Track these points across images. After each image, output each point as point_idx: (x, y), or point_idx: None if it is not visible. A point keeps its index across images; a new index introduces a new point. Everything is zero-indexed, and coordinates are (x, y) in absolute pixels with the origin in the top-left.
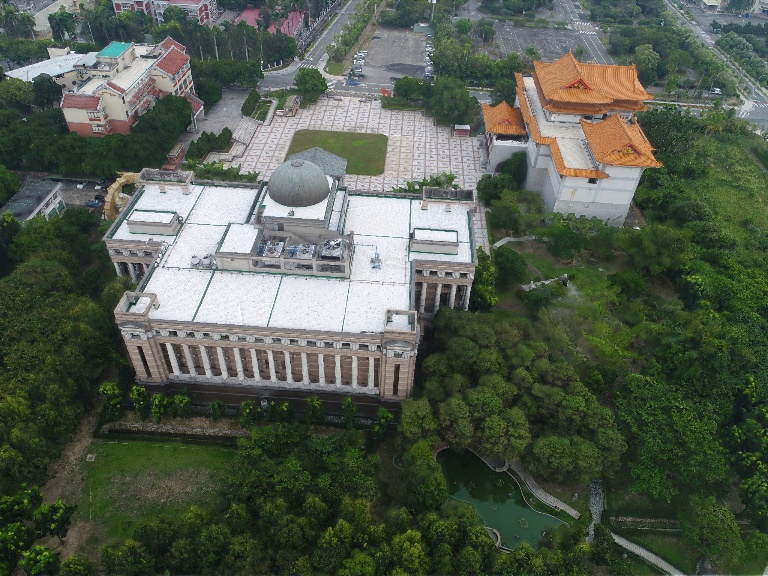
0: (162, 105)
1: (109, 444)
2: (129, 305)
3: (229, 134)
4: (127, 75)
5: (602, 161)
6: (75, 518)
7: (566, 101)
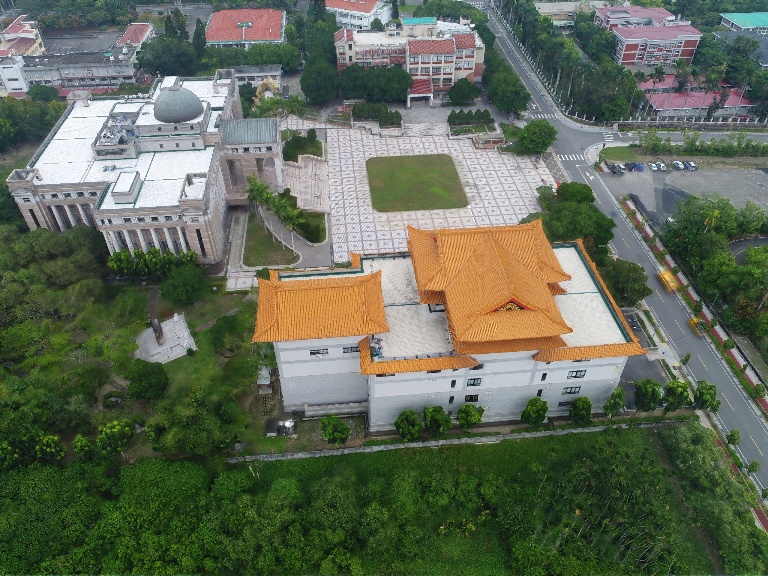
0: (389, 70)
1: None
2: (90, 99)
3: (394, 116)
4: (398, 40)
5: (261, 284)
6: (19, 159)
7: (412, 248)
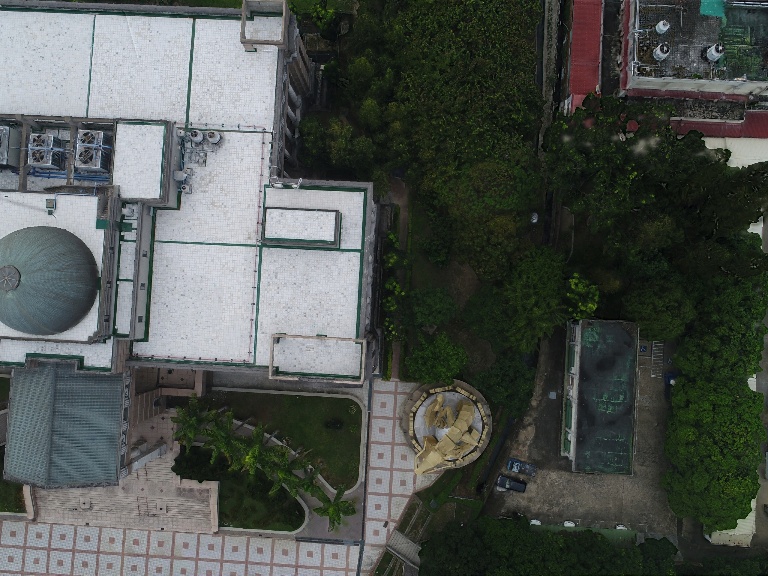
0: None
1: (333, 8)
2: None
3: None
4: None
5: None
6: None
7: None
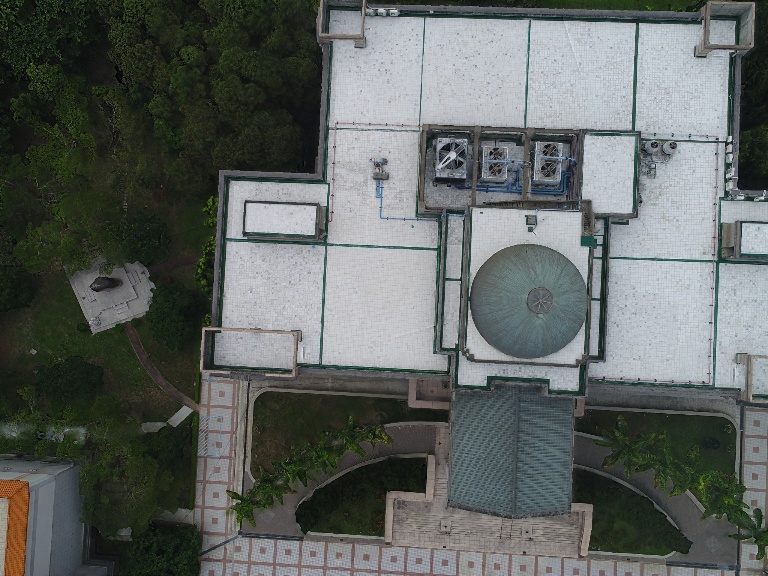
0: None
1: None
2: None
3: None
4: None
5: None
6: None
7: None
